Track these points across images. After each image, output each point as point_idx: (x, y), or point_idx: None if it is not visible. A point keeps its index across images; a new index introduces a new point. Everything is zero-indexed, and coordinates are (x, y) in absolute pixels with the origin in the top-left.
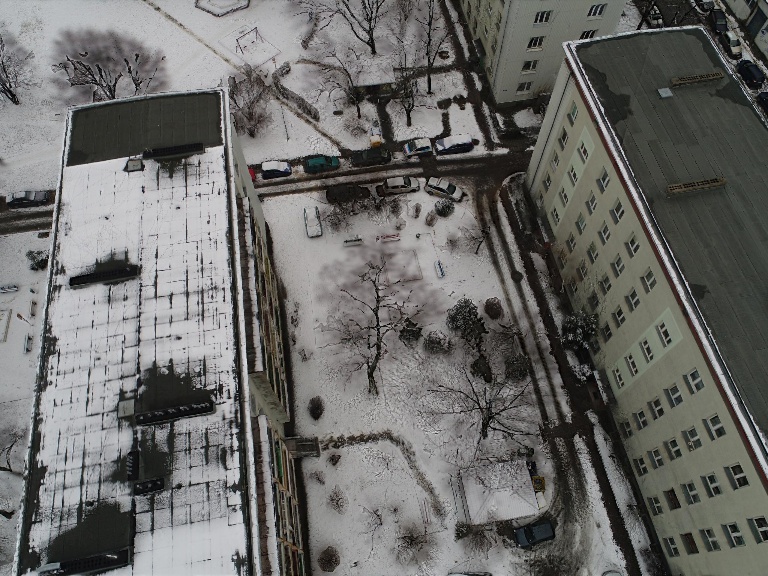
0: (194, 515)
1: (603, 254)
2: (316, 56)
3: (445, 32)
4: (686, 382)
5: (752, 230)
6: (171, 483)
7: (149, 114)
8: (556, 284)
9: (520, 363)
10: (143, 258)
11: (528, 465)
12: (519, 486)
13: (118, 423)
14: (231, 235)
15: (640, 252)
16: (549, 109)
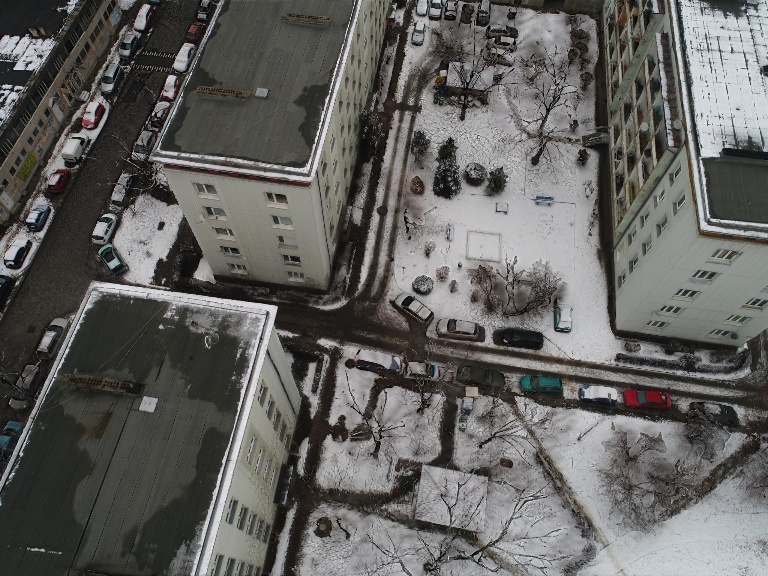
0: None
1: None
2: None
3: None
4: None
5: None
6: None
7: None
8: (353, 193)
9: None
10: (761, 79)
11: (441, 94)
12: None
13: None
14: (688, 83)
15: None
16: None
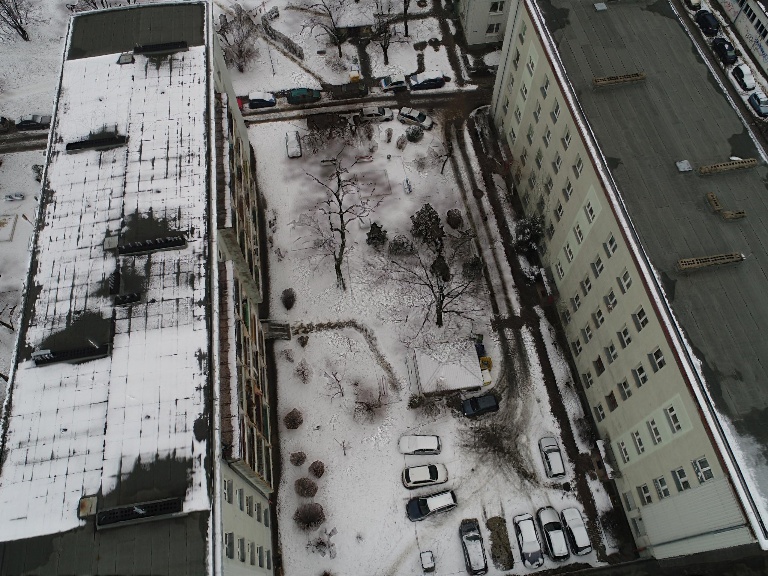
0: (165, 322)
1: (546, 156)
2: (303, 3)
3: None
4: (605, 249)
5: (665, 115)
6: (146, 298)
7: (141, 19)
8: (513, 200)
9: (474, 262)
10: (130, 131)
11: (478, 349)
12: (466, 361)
13: (104, 254)
14: (208, 115)
15: (571, 142)
16: (506, 35)
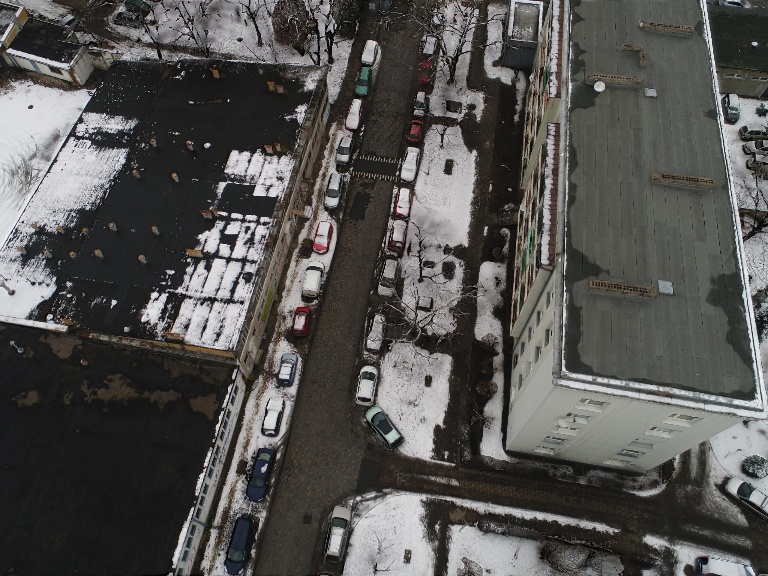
0: None
1: None
2: None
3: None
4: None
5: (646, 138)
6: None
7: None
8: None
9: None
10: None
11: None
12: None
13: None
14: None
15: None
16: None
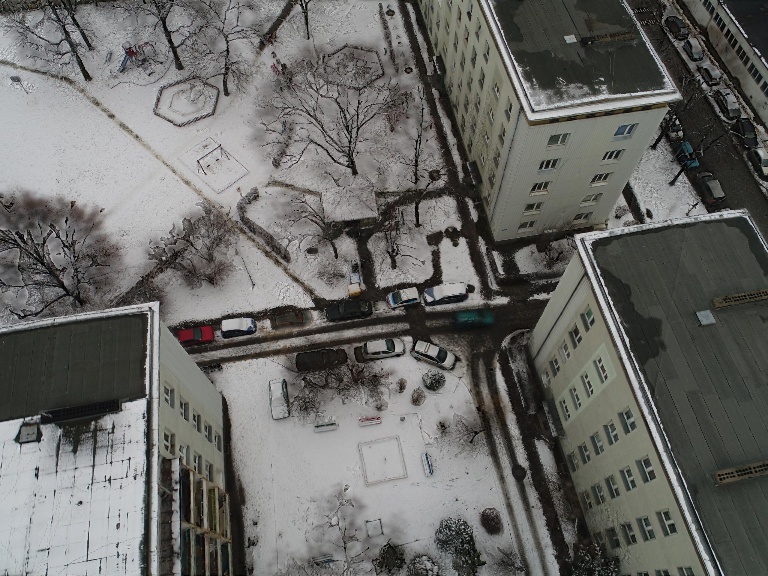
0: None
1: (626, 500)
2: (289, 177)
3: (436, 146)
4: None
5: None
6: None
7: (55, 350)
8: (566, 484)
9: None
10: None
11: None
12: None
13: None
14: (147, 546)
15: (678, 541)
16: (557, 292)
